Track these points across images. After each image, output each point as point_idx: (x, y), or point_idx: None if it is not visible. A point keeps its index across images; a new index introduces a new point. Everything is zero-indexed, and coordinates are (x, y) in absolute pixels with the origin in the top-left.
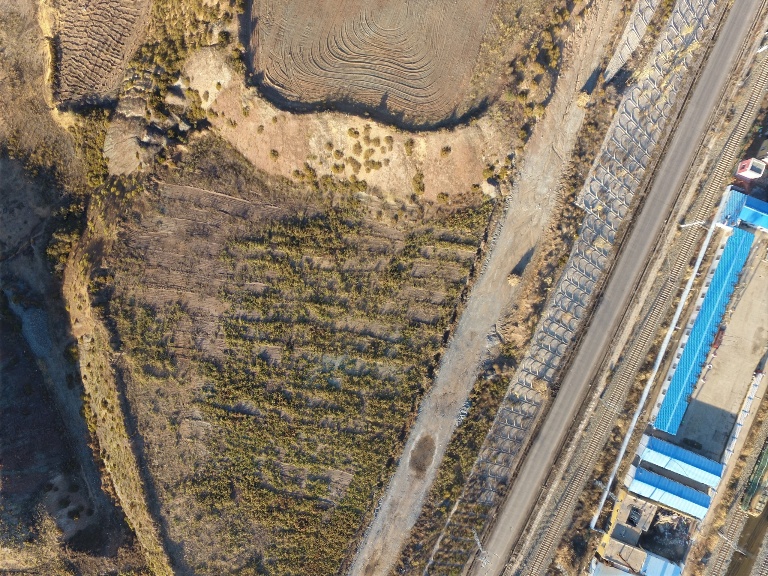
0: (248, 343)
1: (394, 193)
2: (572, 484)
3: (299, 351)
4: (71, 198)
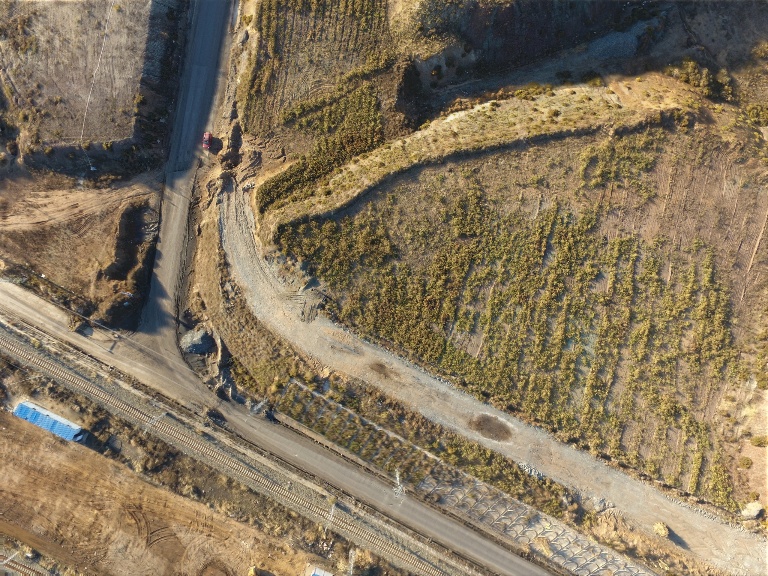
0: (614, 262)
1: (755, 416)
2: (435, 570)
3: (602, 311)
4: (737, 88)
